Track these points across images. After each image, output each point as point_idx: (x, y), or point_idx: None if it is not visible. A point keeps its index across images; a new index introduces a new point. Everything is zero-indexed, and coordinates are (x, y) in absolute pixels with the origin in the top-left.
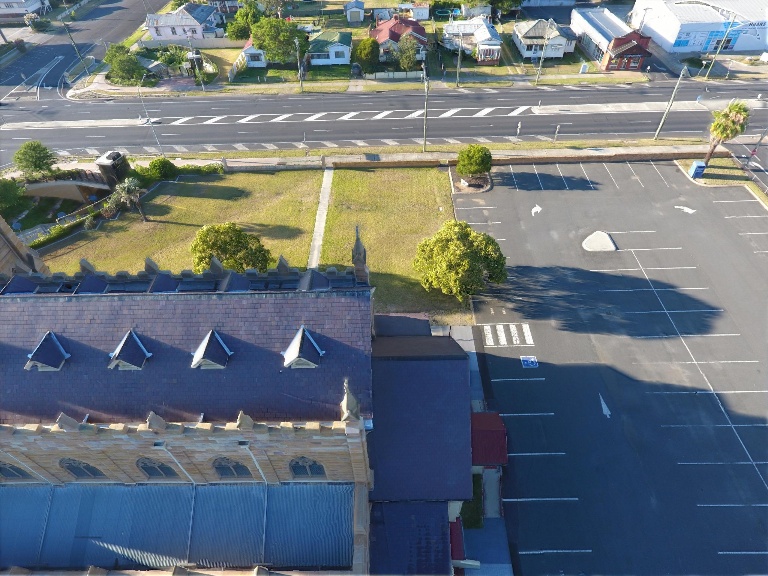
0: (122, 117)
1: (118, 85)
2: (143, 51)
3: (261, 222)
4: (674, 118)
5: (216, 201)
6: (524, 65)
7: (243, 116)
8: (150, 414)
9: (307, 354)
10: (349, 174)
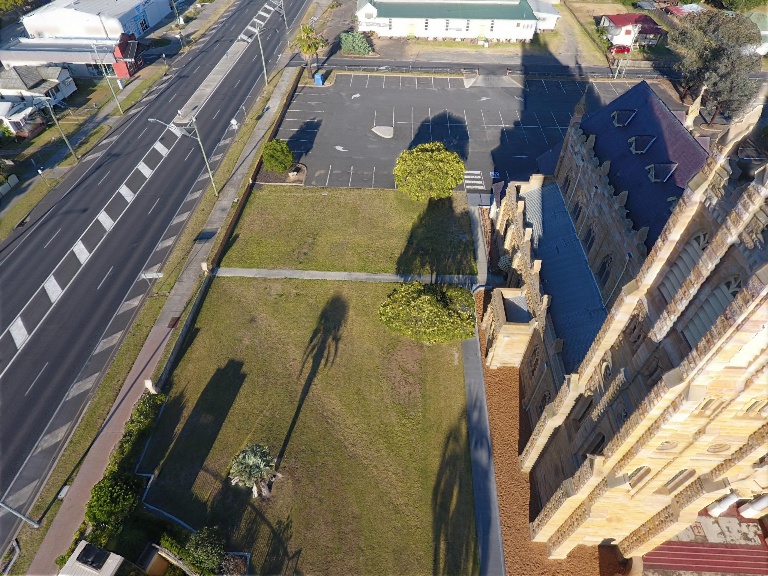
0: None
1: None
2: None
3: (310, 332)
4: (241, 71)
5: (243, 393)
6: (70, 111)
7: None
8: None
9: None
10: (236, 253)
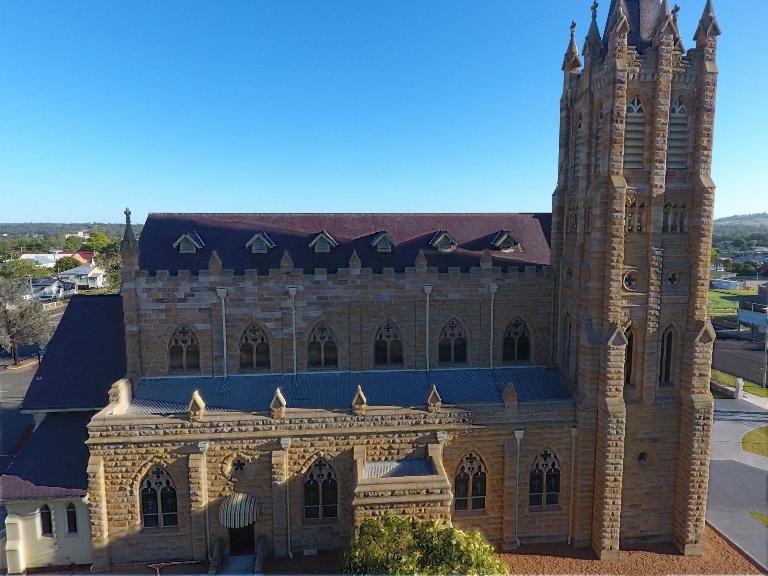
0: None
1: None
2: None
3: None
4: None
5: None
6: None
7: None
8: None
9: None
10: None
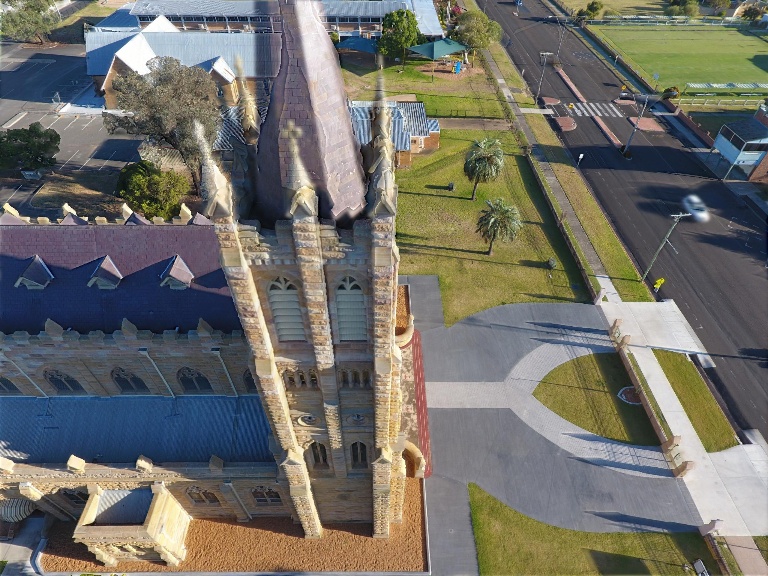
0: None
1: None
2: None
3: None
4: None
5: None
6: None
7: None
8: (64, 205)
9: None
10: None
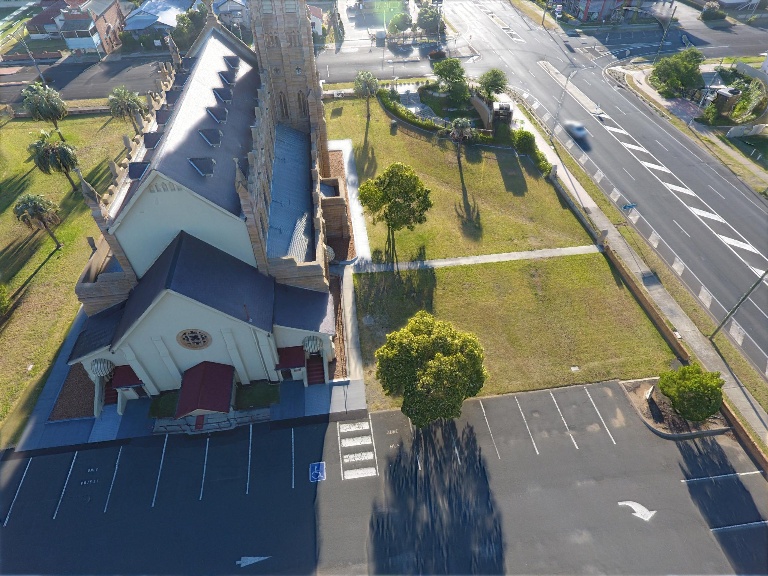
0: (596, 100)
1: (649, 81)
2: (728, 71)
3: (482, 218)
4: None
5: (501, 184)
6: None
7: (658, 162)
8: None
9: (133, 169)
10: (600, 266)
